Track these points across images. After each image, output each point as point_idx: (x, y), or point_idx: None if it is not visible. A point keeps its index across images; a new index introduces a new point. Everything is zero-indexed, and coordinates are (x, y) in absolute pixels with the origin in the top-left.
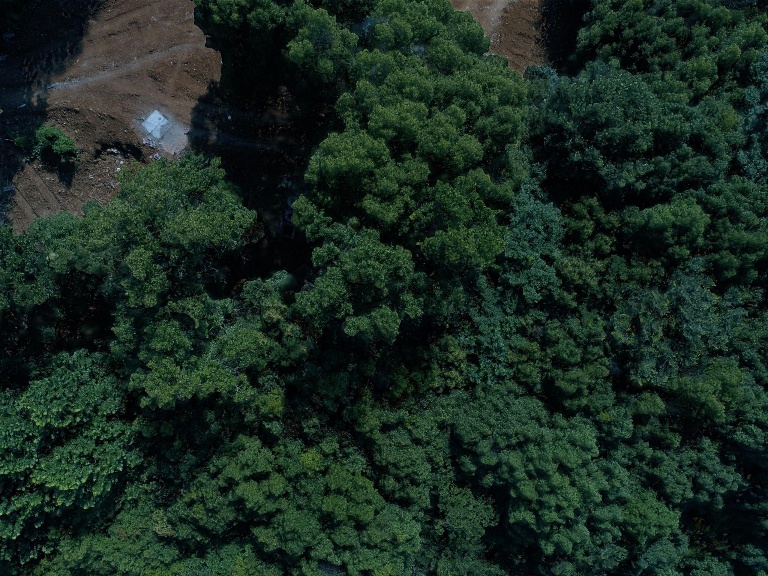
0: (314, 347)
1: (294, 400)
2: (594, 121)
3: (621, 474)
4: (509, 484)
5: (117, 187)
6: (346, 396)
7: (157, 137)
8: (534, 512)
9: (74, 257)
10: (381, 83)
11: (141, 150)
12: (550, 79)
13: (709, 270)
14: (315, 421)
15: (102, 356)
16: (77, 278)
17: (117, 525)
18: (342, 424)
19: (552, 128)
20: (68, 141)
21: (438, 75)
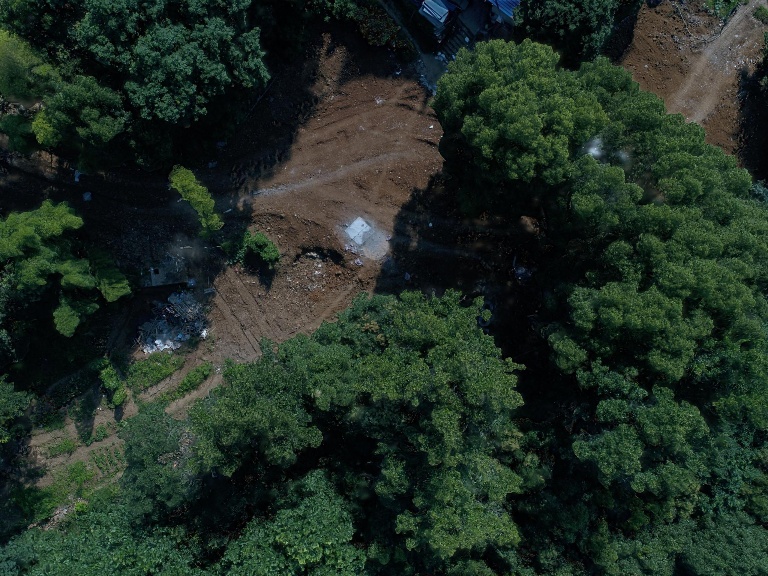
0: None
1: (525, 527)
2: None
3: None
4: None
5: (314, 290)
6: (585, 528)
7: (359, 243)
8: None
9: None
10: (665, 236)
11: (343, 255)
12: (767, 200)
13: None
14: (555, 554)
15: (323, 473)
16: (330, 410)
17: None
18: (575, 554)
19: None
20: (275, 248)
21: (717, 227)
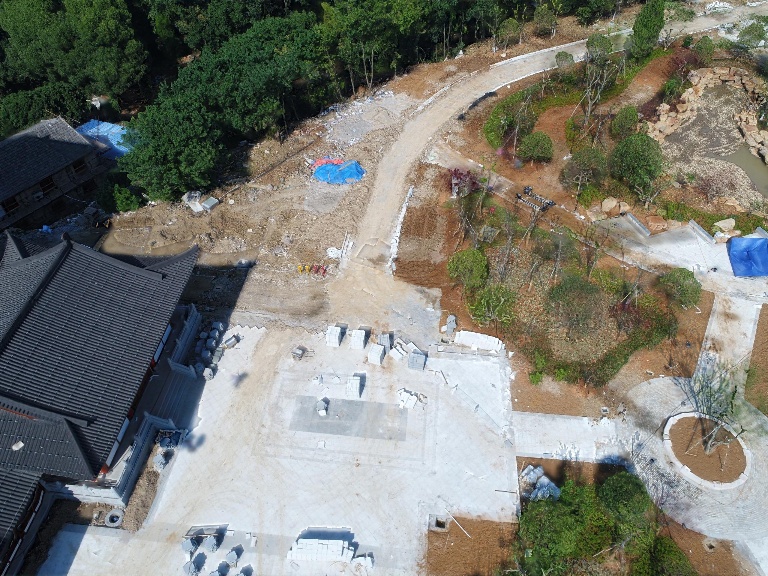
0: None
1: None
2: None
3: None
4: None
5: None
6: None
7: None
8: None
9: None
10: None
11: None
12: None
13: None
14: None
15: None
16: None
17: None
18: None
19: None
20: None
21: None
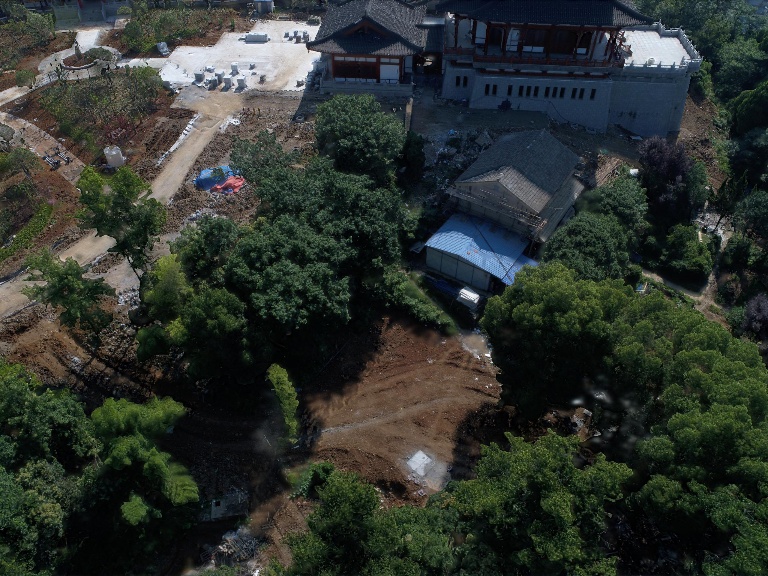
0: None
1: None
2: None
3: None
4: None
5: None
6: None
7: (421, 474)
8: None
9: None
10: None
11: (406, 486)
12: None
13: None
14: None
15: None
16: None
17: None
18: None
19: None
20: None
21: None
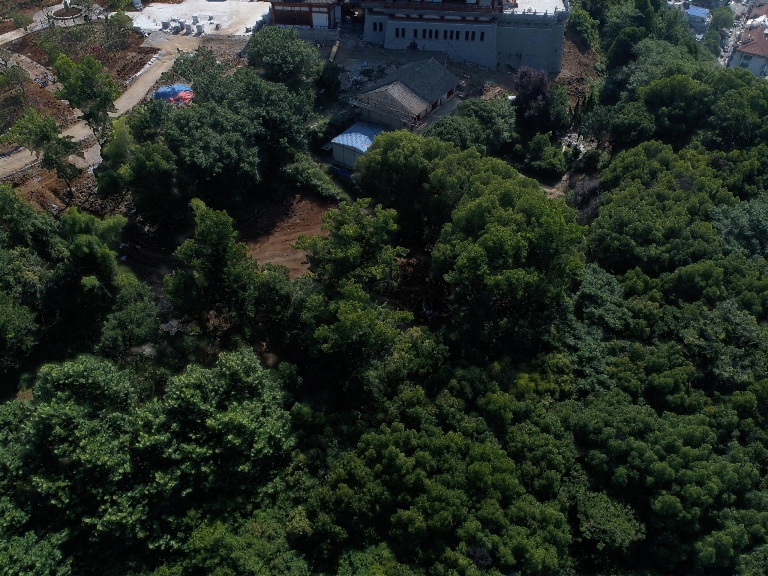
0: (447, 355)
1: (431, 399)
2: (620, 221)
3: (747, 461)
4: (643, 475)
5: None
6: None
7: None
8: (677, 495)
9: (277, 279)
10: None
11: None
12: None
13: (741, 308)
14: None
15: None
16: (273, 297)
17: (252, 522)
18: None
19: (594, 242)
20: None
21: None
